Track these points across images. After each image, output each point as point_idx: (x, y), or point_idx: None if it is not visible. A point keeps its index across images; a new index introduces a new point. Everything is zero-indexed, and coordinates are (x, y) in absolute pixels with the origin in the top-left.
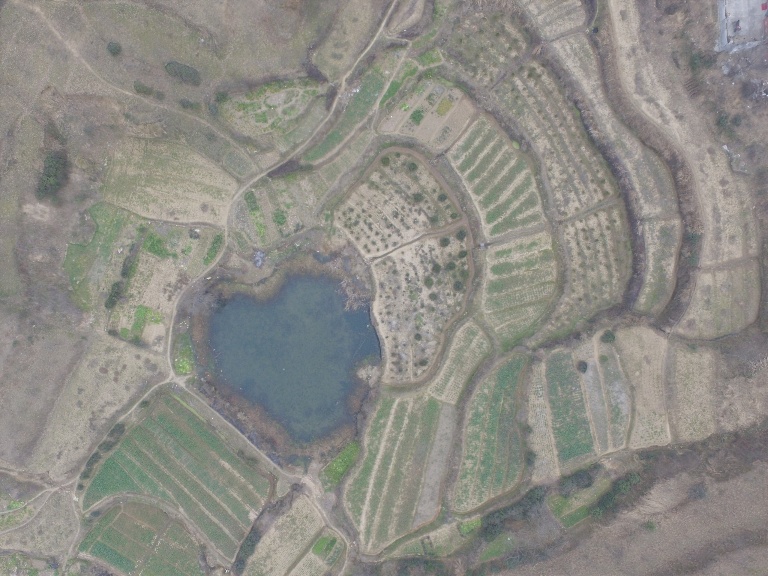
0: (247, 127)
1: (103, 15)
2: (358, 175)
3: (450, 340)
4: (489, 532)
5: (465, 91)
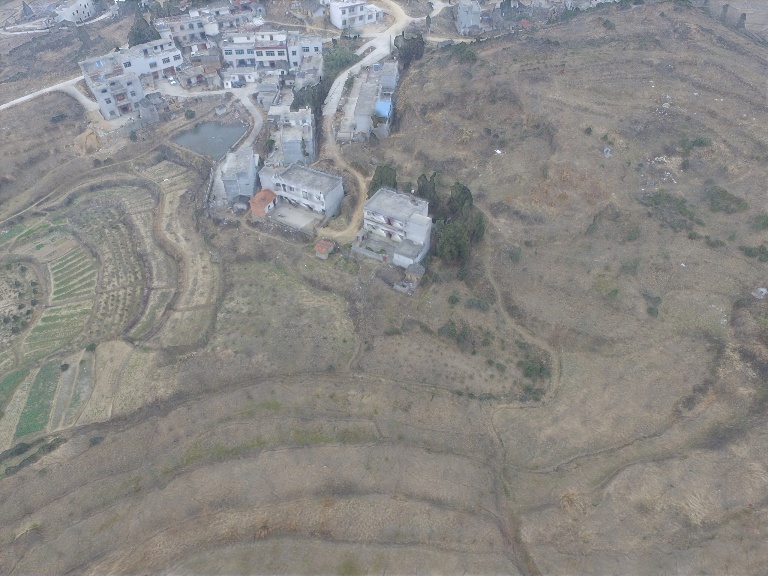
0: None
1: None
2: None
3: None
4: None
5: (77, 237)
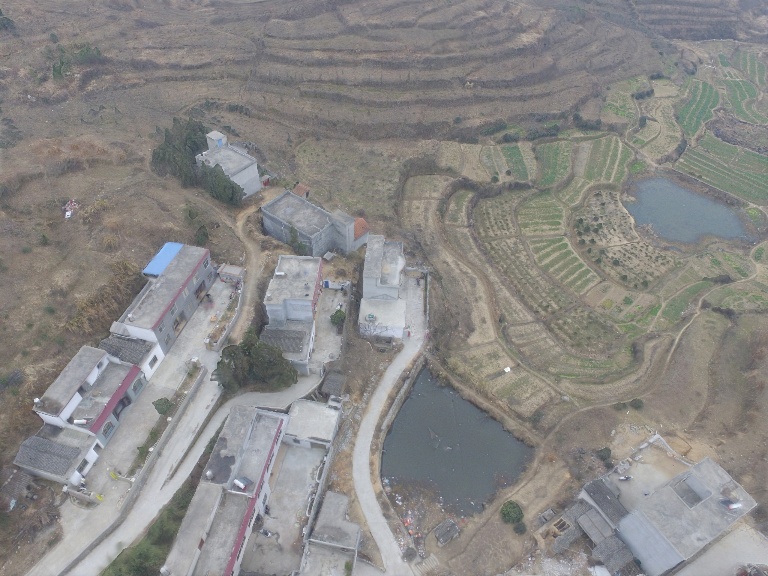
0: (767, 295)
1: None
2: None
3: None
4: None
5: None
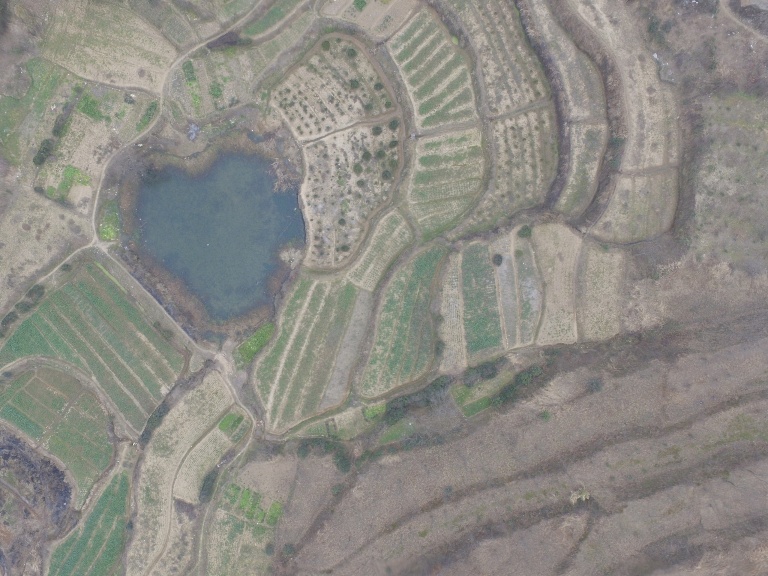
0: None
1: None
2: (298, 57)
3: (373, 227)
4: (391, 414)
5: None
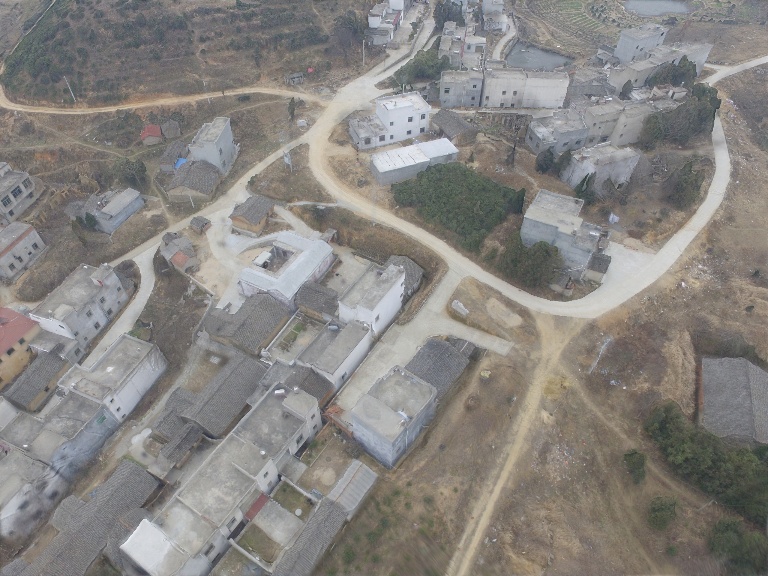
0: None
1: None
2: None
3: None
4: None
5: None
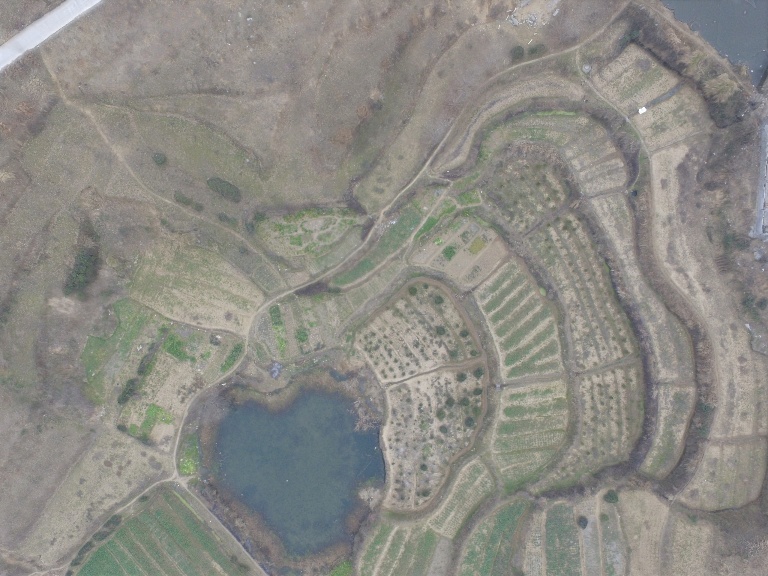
0: (281, 247)
1: (152, 126)
2: (384, 301)
3: (455, 475)
4: None
5: (499, 233)
